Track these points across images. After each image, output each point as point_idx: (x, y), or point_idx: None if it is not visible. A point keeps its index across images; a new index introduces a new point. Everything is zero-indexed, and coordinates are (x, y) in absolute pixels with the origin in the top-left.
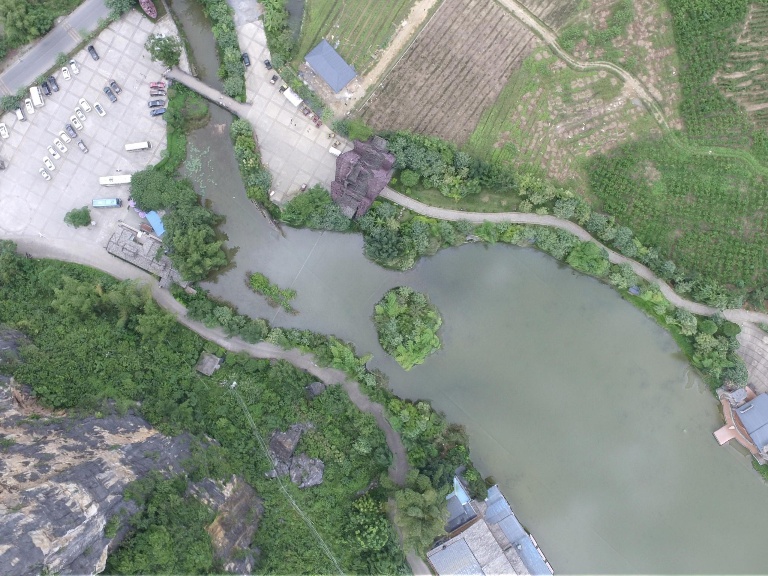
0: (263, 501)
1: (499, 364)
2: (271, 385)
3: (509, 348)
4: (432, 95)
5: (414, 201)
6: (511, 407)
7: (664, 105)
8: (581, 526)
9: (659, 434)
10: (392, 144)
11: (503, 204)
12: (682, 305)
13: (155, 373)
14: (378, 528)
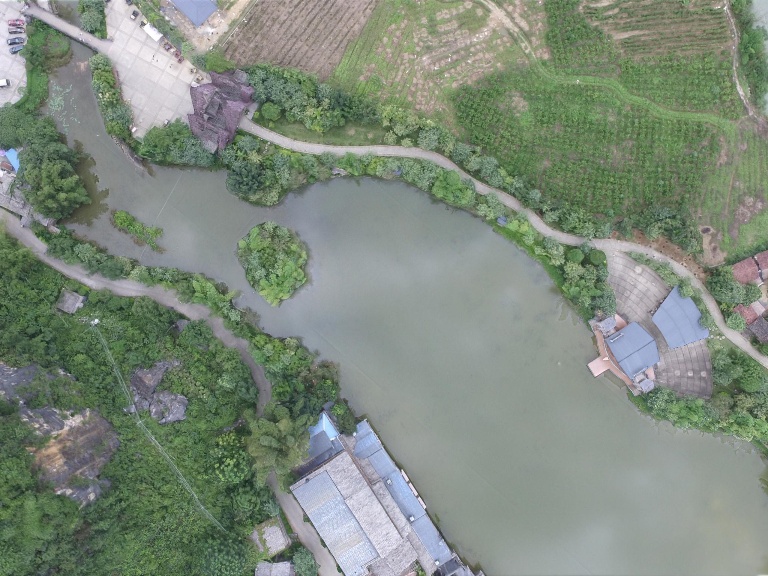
0: (118, 435)
1: (370, 299)
2: (136, 323)
3: (379, 283)
4: (296, 29)
5: (279, 136)
6: (383, 342)
7: (531, 35)
8: (455, 461)
9: (533, 367)
10: (252, 76)
11: (369, 137)
12: (552, 235)
13: (9, 309)
14: (237, 461)
